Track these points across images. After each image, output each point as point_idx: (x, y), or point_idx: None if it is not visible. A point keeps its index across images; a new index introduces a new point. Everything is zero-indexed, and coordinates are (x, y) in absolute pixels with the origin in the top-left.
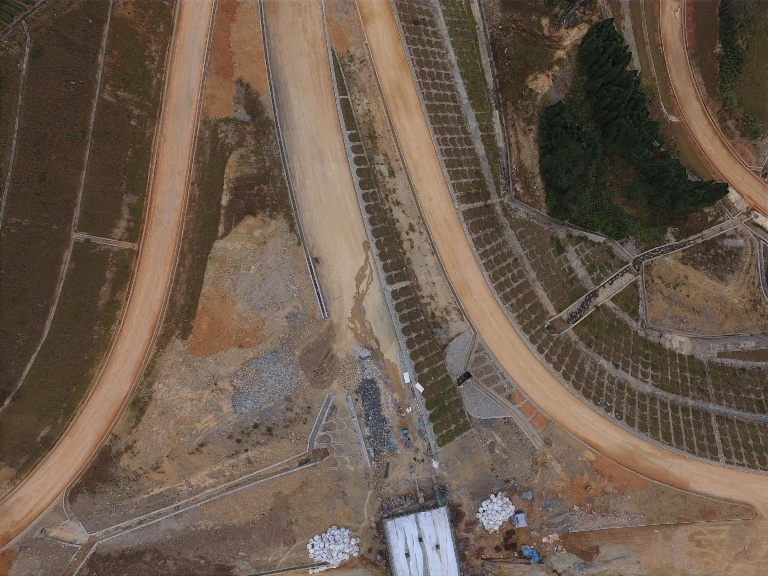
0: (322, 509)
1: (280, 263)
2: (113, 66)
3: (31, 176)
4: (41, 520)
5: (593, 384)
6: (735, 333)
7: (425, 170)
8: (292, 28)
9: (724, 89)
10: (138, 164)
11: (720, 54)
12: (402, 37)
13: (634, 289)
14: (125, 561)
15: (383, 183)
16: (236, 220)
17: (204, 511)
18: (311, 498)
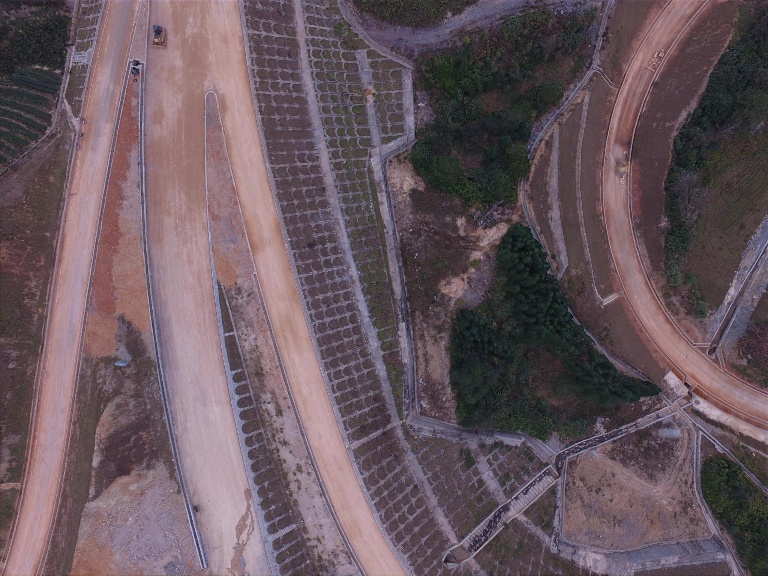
0: None
1: (158, 513)
2: None
3: None
4: None
5: None
6: (659, 542)
7: (315, 407)
8: (177, 259)
9: (668, 266)
10: (19, 404)
11: (666, 228)
12: (293, 267)
13: (551, 496)
14: None
15: (270, 422)
16: (107, 483)
17: None
18: None
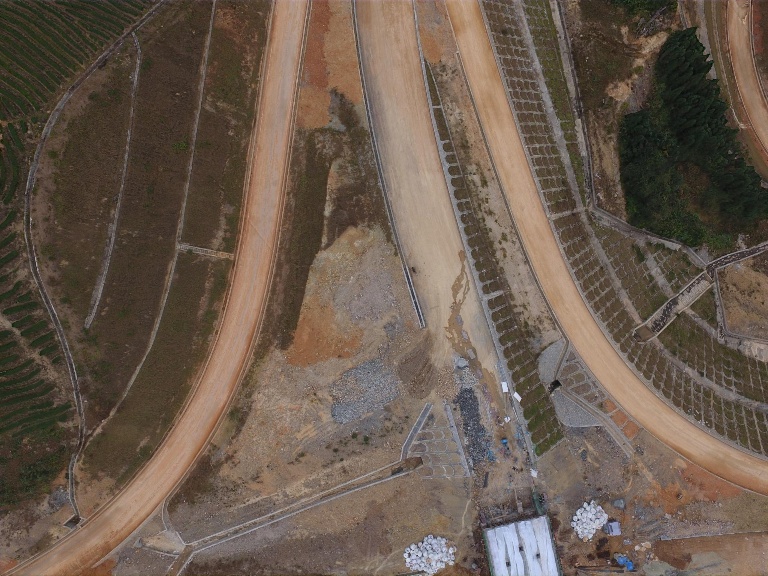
0: (417, 518)
1: (378, 273)
2: (214, 77)
3: (141, 188)
4: (140, 530)
5: (681, 392)
6: None
7: (517, 179)
8: (385, 38)
9: None
10: (234, 174)
11: None
12: (493, 47)
13: (711, 296)
14: (223, 571)
15: (476, 193)
16: (339, 231)
17: (299, 520)
18: (405, 507)
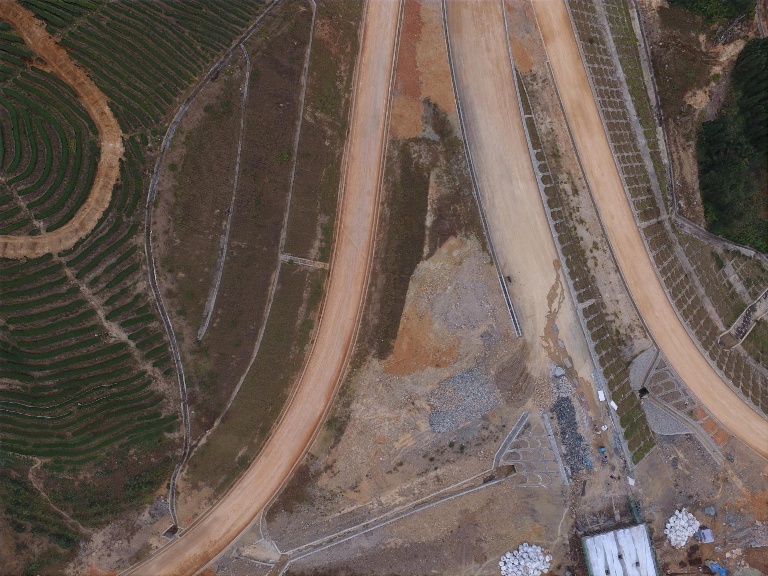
0: (510, 526)
1: (475, 282)
2: (313, 87)
3: (250, 199)
4: (238, 540)
5: (767, 399)
6: None
7: (606, 188)
8: (476, 48)
9: None
10: (329, 184)
11: None
12: (582, 56)
13: None
14: None
15: (567, 201)
16: (441, 241)
17: (393, 529)
18: (498, 515)
